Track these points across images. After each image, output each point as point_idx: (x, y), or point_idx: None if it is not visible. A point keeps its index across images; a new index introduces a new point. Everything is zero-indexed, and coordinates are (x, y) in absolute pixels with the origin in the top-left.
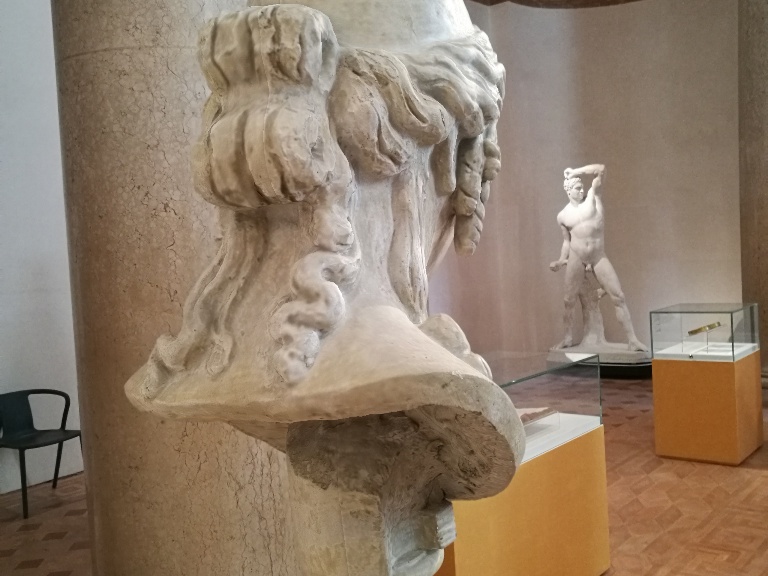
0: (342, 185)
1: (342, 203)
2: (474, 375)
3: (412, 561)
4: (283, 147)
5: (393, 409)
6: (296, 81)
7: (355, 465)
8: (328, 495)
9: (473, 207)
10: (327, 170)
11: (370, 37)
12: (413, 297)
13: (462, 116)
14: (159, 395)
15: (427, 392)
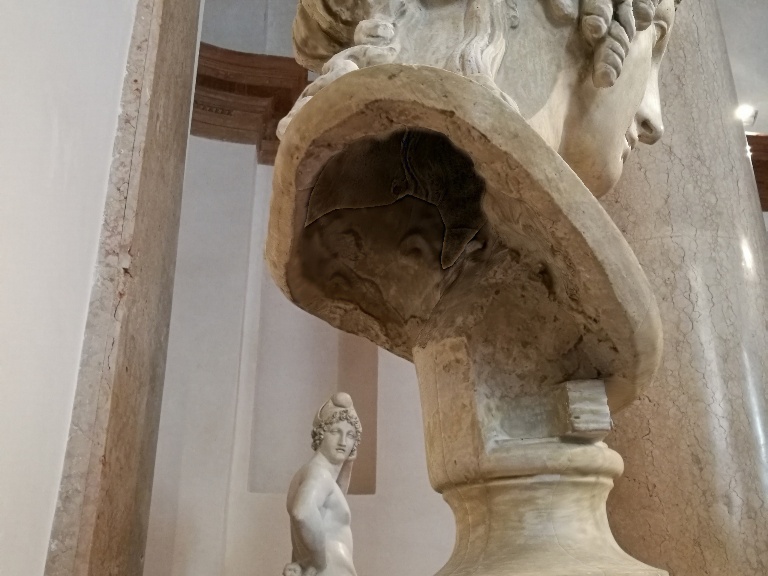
0: None
1: (387, 12)
2: (437, 68)
3: (528, 439)
4: None
5: (341, 115)
6: None
7: (454, 315)
8: (426, 353)
9: (596, 24)
10: None
11: None
12: None
13: None
14: None
15: (370, 86)
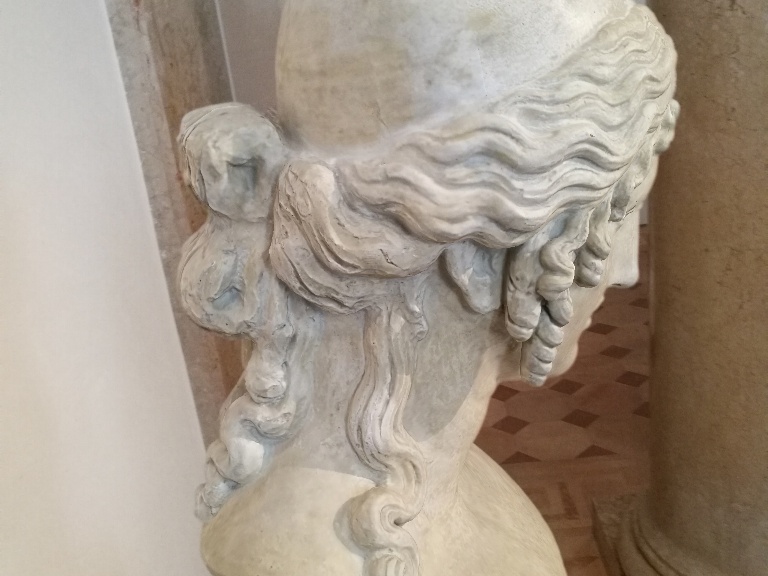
0: (267, 332)
1: (275, 348)
2: None
3: None
4: (183, 301)
5: None
6: None
7: None
8: None
9: (518, 336)
10: (242, 319)
11: (327, 135)
12: (366, 457)
13: None
14: None
15: None
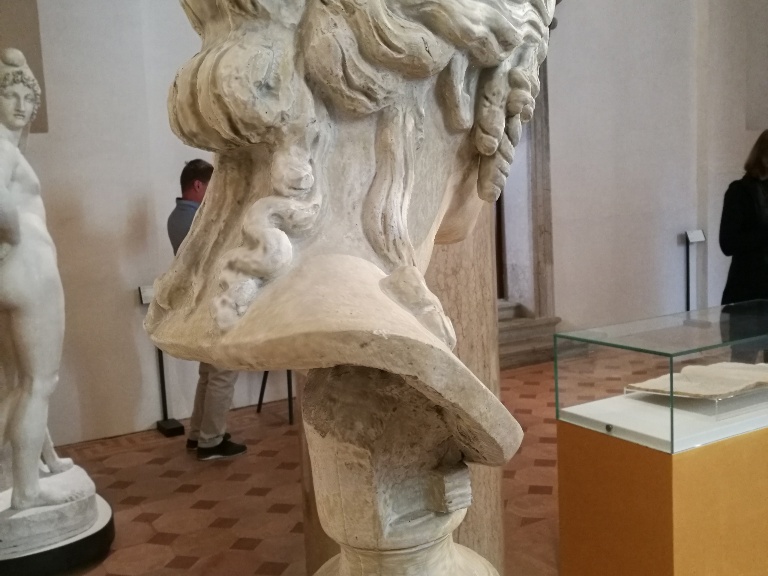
0: (301, 125)
1: (303, 144)
2: (404, 336)
3: (414, 521)
4: (224, 87)
5: (309, 365)
6: (253, 15)
7: (352, 416)
8: (326, 443)
9: (491, 146)
10: (280, 110)
11: None
12: (386, 246)
13: (462, 43)
14: (155, 331)
15: (342, 350)
